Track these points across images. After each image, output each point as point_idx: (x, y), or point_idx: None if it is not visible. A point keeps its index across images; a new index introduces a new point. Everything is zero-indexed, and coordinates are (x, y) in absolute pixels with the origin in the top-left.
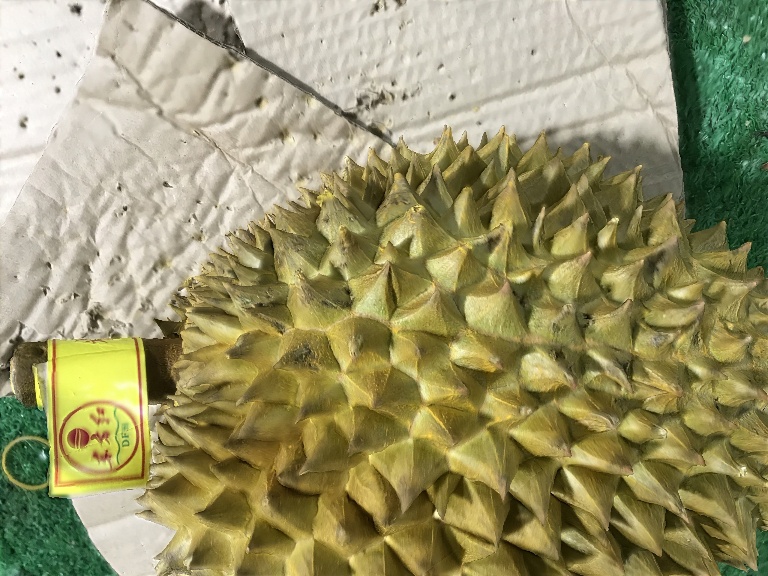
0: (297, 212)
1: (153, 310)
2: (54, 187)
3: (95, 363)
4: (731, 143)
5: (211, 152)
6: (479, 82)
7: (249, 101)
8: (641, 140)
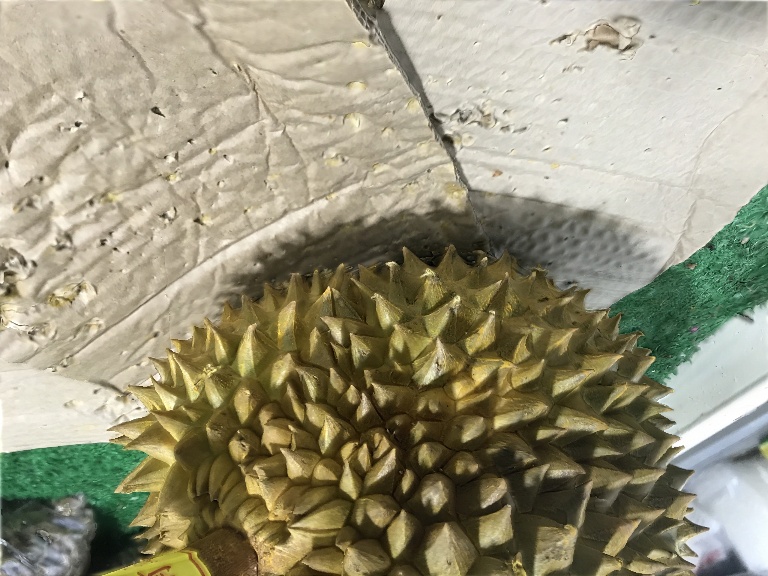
0: (444, 490)
1: (71, 249)
2: None
3: None
4: None
5: (243, 94)
6: (581, 149)
7: (344, 80)
8: (651, 253)
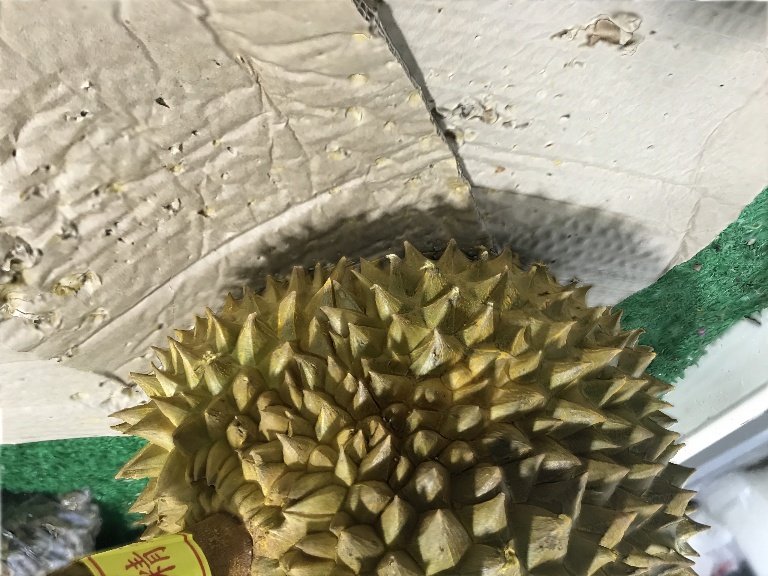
0: (438, 477)
1: (77, 238)
2: None
3: None
4: None
5: (246, 86)
6: (584, 145)
7: (345, 73)
8: (655, 252)
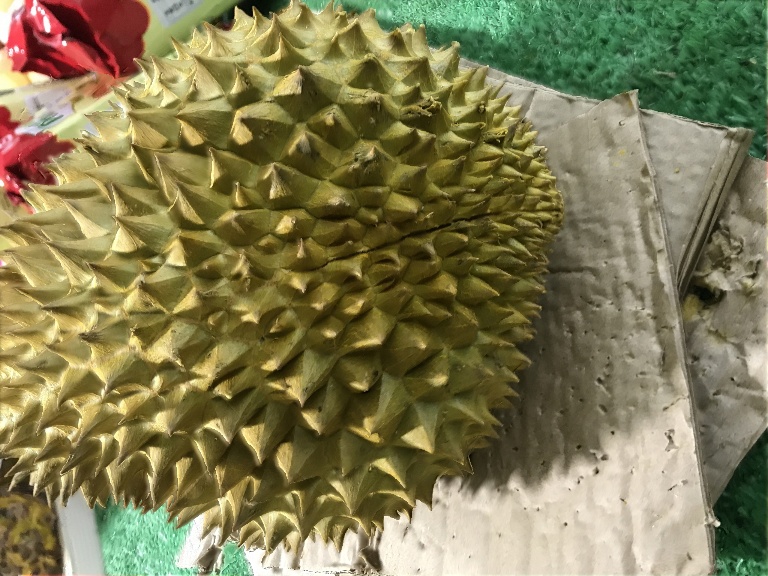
0: None
1: None
2: None
3: None
4: (517, 13)
5: None
6: None
7: None
8: None
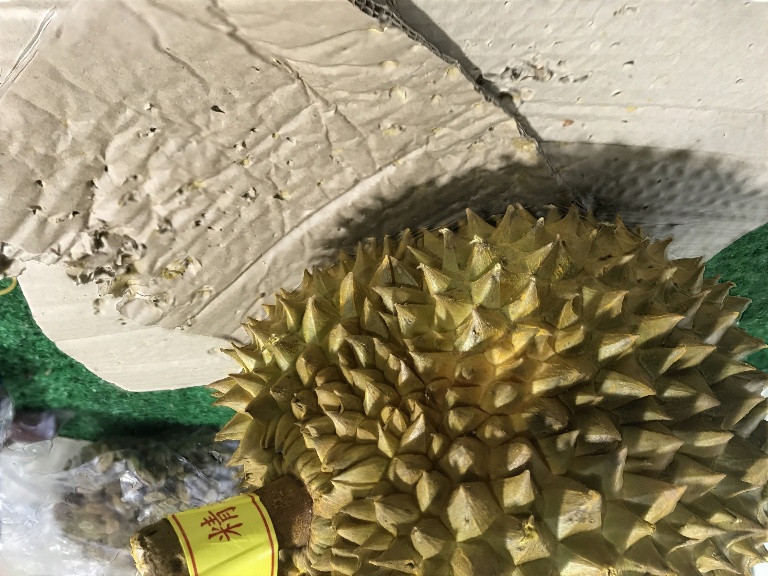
0: (468, 453)
1: (172, 232)
2: (51, 99)
3: (236, 570)
4: None
5: (289, 83)
6: (658, 89)
7: (373, 62)
8: (765, 189)
